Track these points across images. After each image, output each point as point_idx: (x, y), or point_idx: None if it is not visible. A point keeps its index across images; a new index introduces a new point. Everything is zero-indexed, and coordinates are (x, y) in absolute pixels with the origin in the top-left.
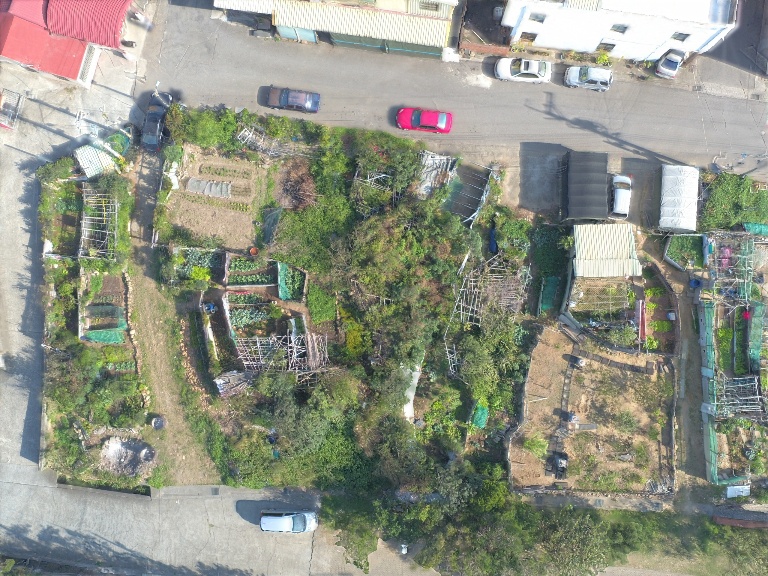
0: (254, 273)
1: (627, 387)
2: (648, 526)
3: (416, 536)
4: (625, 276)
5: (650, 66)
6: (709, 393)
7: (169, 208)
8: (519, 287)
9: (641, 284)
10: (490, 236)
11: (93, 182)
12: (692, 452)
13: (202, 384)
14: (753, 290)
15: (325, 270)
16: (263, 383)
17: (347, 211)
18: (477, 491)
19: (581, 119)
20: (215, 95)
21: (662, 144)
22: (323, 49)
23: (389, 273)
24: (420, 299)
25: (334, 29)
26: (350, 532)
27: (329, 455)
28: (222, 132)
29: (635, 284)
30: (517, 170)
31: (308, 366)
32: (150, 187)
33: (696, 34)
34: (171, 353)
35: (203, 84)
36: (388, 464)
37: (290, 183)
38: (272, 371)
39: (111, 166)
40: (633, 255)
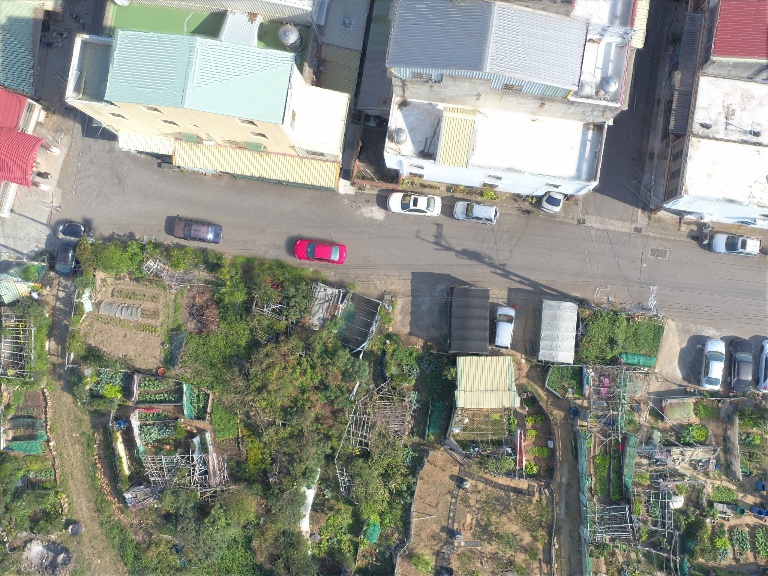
0: (162, 392)
1: (510, 507)
2: None
3: None
4: (504, 407)
5: (536, 201)
6: (585, 518)
7: (83, 330)
8: (406, 414)
9: (523, 411)
10: (381, 362)
11: (11, 307)
12: (571, 570)
13: (115, 494)
14: (630, 418)
15: (227, 391)
16: (165, 501)
17: (247, 336)
18: None
19: (470, 250)
20: (125, 224)
21: (547, 275)
22: (226, 181)
23: (285, 398)
24: (314, 422)
25: (231, 170)
26: None
27: (230, 565)
28: (129, 262)
29: (518, 411)
30: (408, 299)
31: (209, 484)
32: (66, 309)
33: (566, 185)
34: (87, 464)
35: (114, 214)
36: None
37: (196, 308)
38: (176, 487)
39: (27, 293)
40: (512, 387)
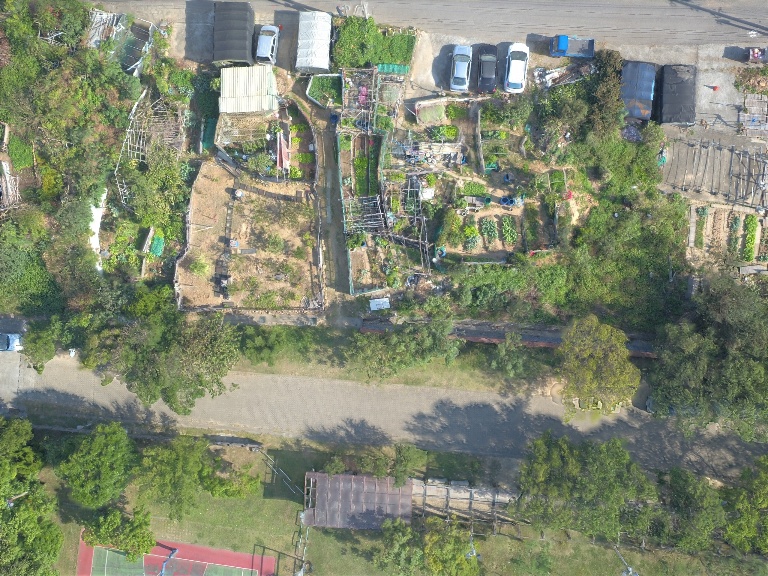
0: None
1: (281, 215)
2: (303, 338)
3: (87, 344)
4: (263, 111)
5: None
6: None
7: None
8: (179, 127)
9: (289, 121)
10: None
11: None
12: (340, 271)
13: None
14: (387, 123)
15: None
16: None
17: (37, 68)
18: (128, 299)
19: None
20: None
21: None
22: None
23: (69, 120)
24: (97, 142)
25: None
26: (25, 339)
27: (28, 283)
28: None
29: (284, 122)
30: (183, 26)
31: (3, 204)
32: None
33: None
34: None
35: None
36: (67, 285)
37: None
38: None
39: None
40: (270, 92)
